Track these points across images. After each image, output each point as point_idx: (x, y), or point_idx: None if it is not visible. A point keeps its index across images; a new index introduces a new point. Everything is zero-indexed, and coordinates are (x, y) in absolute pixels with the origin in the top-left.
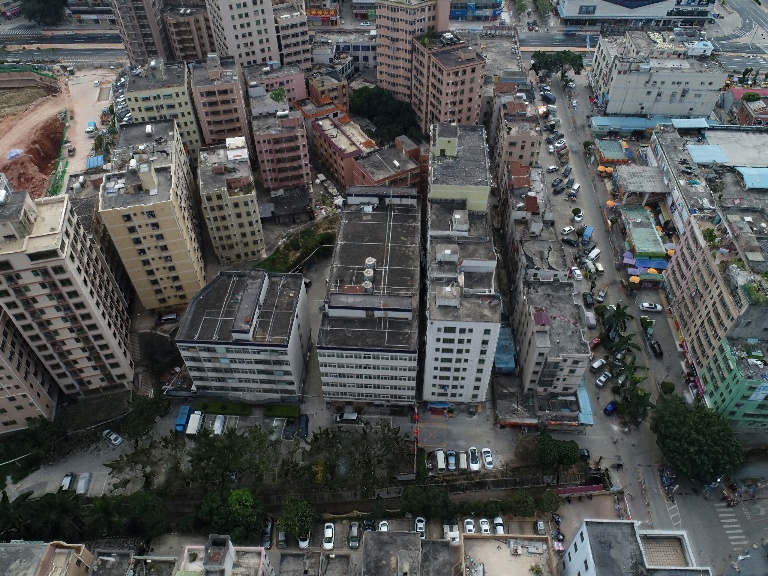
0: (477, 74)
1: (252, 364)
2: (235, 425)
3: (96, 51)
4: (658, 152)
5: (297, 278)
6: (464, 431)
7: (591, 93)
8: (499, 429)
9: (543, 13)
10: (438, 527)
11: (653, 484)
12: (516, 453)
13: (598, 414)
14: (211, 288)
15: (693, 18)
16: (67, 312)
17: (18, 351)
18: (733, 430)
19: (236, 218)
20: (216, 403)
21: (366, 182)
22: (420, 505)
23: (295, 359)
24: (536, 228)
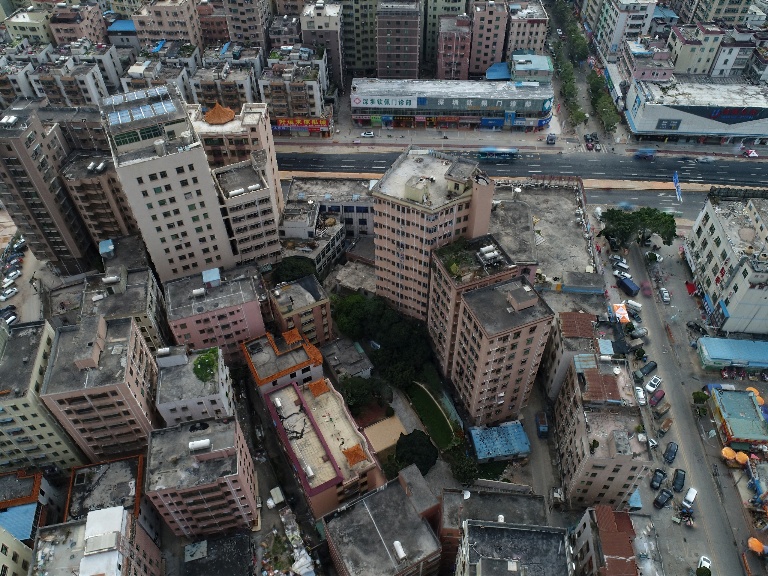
0: (538, 332)
1: None
2: None
3: None
4: None
5: None
6: None
7: (688, 275)
8: None
9: (607, 125)
10: None
11: None
12: None
13: None
14: None
15: None
16: None
17: None
18: None
19: None
20: None
21: (344, 572)
22: None
23: None
24: None
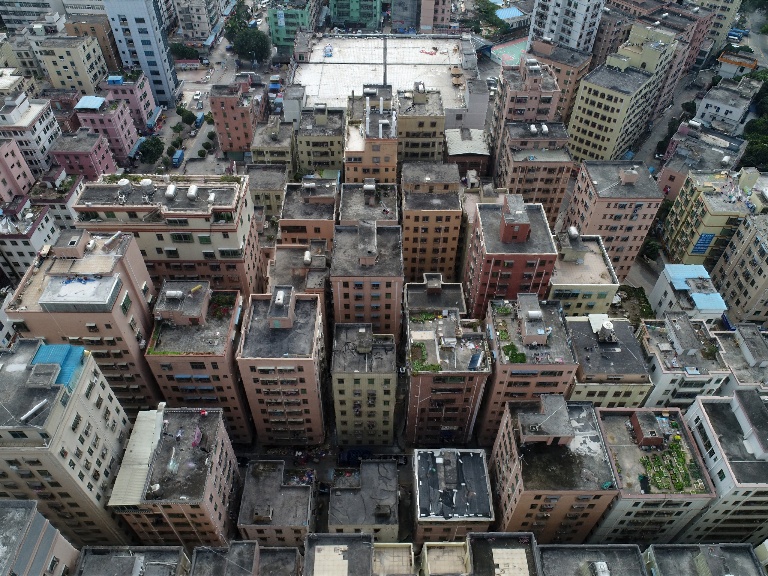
0: None
1: (32, 7)
2: None
3: None
4: None
5: None
6: None
7: None
8: None
9: None
10: None
11: (232, 68)
12: None
13: (223, 51)
14: None
15: None
16: None
17: None
18: (263, 34)
19: None
20: None
21: None
22: None
23: (59, 13)
24: None
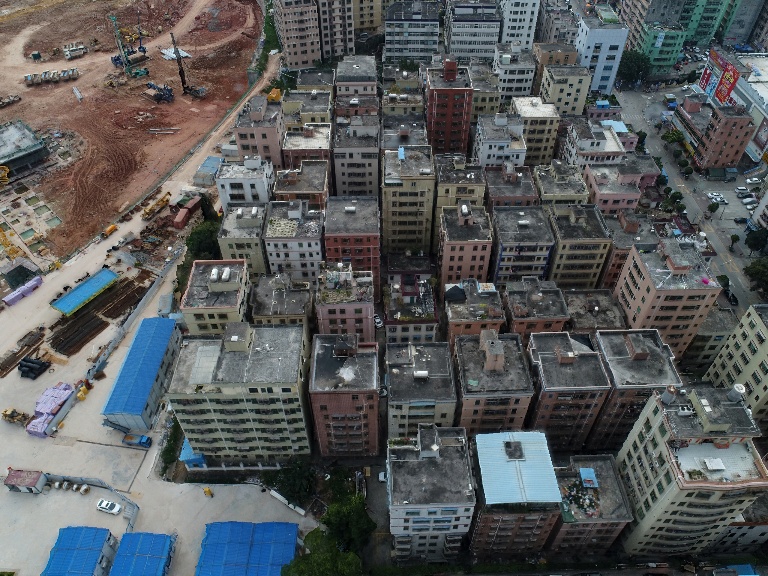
0: None
1: (419, 36)
2: None
3: None
4: None
5: (434, 4)
6: None
7: None
8: None
9: None
10: None
11: None
12: None
13: None
14: (393, 8)
15: None
16: None
17: None
18: None
19: None
20: None
21: None
22: None
23: None
24: None
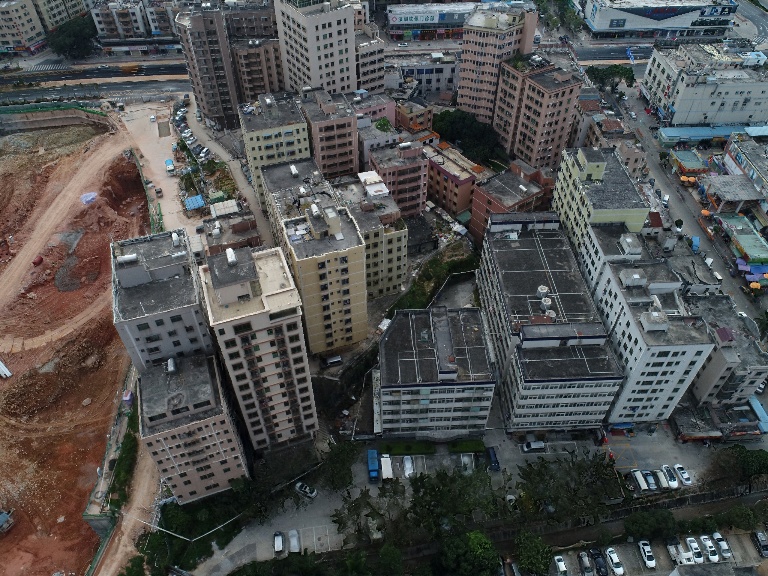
0: (573, 95)
1: (451, 403)
2: (424, 465)
3: (137, 84)
4: (742, 160)
5: (474, 312)
6: (649, 449)
7: (645, 105)
8: (681, 444)
9: (574, 28)
10: (662, 548)
11: None
12: (717, 467)
13: None
14: (392, 328)
15: (715, 27)
16: (285, 368)
17: (229, 412)
18: None
19: (387, 254)
20: (399, 444)
21: (493, 208)
22: (652, 529)
23: None
24: (670, 243)
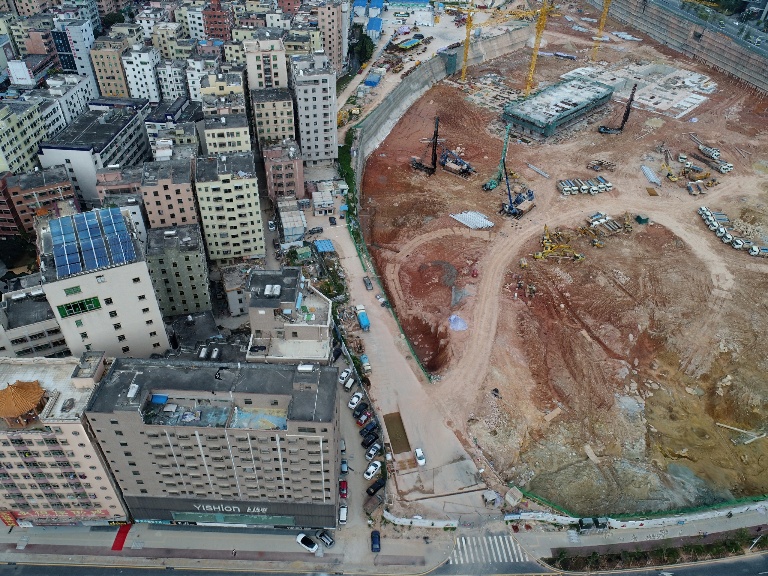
0: None
1: None
2: None
3: None
4: None
5: (149, 122)
6: None
7: None
8: None
9: None
10: None
11: None
12: None
13: None
14: None
15: None
16: None
17: None
18: None
19: None
20: None
21: None
22: None
23: None
24: None
